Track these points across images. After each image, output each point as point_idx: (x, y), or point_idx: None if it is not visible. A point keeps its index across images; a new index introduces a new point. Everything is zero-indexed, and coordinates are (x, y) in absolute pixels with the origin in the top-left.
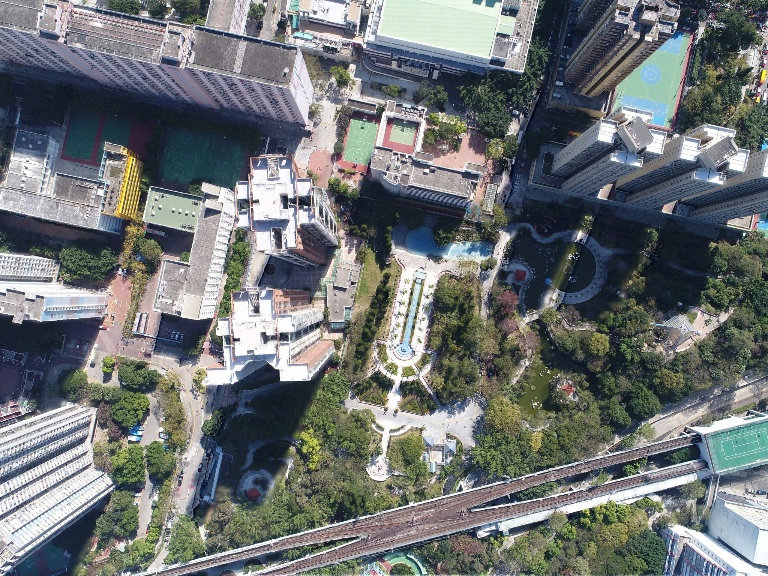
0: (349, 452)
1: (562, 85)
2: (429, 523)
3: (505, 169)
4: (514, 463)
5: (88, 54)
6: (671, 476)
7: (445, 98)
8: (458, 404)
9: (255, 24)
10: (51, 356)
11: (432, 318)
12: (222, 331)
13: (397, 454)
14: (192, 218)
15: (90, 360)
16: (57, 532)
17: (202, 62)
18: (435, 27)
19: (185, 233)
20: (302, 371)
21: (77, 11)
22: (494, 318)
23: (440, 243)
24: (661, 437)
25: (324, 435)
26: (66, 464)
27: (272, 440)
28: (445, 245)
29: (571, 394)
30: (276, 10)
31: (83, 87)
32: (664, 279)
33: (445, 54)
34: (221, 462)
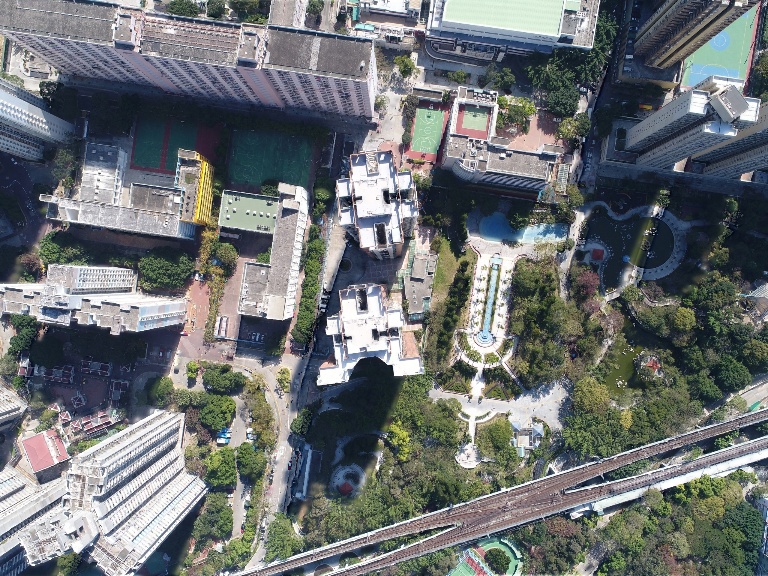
0: (437, 442)
1: (632, 58)
2: (523, 507)
3: (577, 148)
4: (605, 443)
5: (162, 62)
6: (765, 447)
7: (513, 80)
8: (542, 387)
9: (313, 19)
10: (136, 365)
11: (511, 303)
12: (331, 330)
13: (486, 441)
14: (267, 219)
15: (173, 366)
16: None
17: (277, 61)
18: (501, 8)
19: (258, 234)
20: (414, 365)
21: (149, 19)
22: (574, 299)
23: (516, 227)
24: (750, 408)
25: (412, 426)
26: (163, 470)
27: (360, 434)
28: (521, 229)
29: (656, 370)
30: (334, 3)
31: (147, 95)
32: (747, 249)
33: (512, 35)
34: (311, 459)
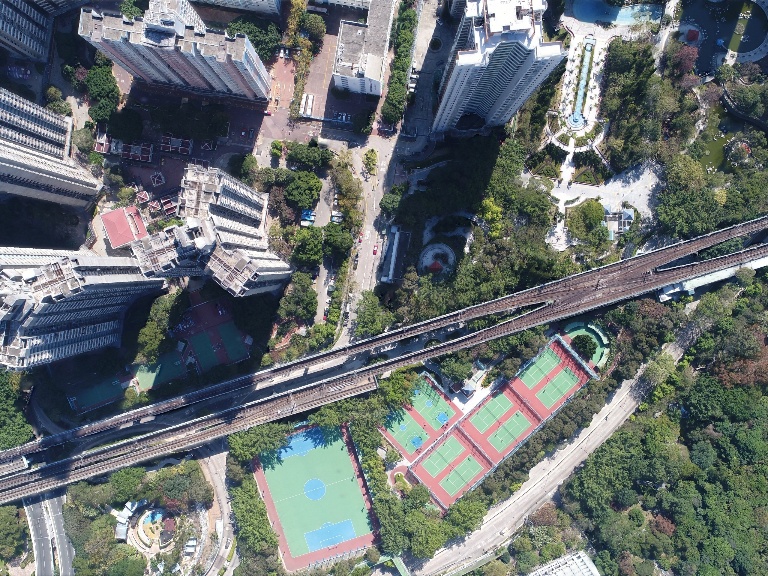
0: None
1: None
2: (615, 286)
3: None
4: (699, 219)
5: None
6: None
7: None
8: (633, 172)
9: None
10: (217, 144)
11: (603, 85)
12: (471, 13)
13: (578, 220)
14: None
15: (256, 147)
16: (265, 286)
17: None
18: None
19: (346, 10)
20: (555, 50)
21: None
22: (669, 79)
23: (613, 2)
24: None
25: (505, 204)
26: None
27: (450, 215)
28: (619, 3)
29: None
30: None
31: None
32: None
33: None
34: (398, 240)
